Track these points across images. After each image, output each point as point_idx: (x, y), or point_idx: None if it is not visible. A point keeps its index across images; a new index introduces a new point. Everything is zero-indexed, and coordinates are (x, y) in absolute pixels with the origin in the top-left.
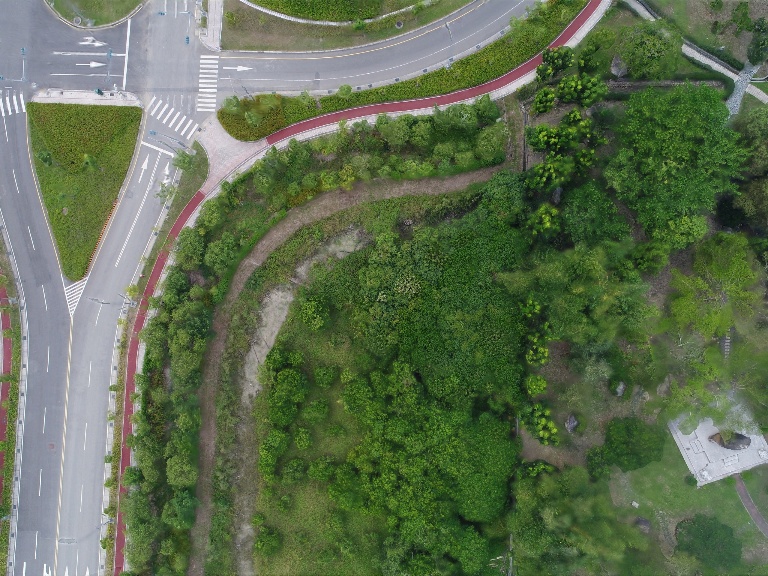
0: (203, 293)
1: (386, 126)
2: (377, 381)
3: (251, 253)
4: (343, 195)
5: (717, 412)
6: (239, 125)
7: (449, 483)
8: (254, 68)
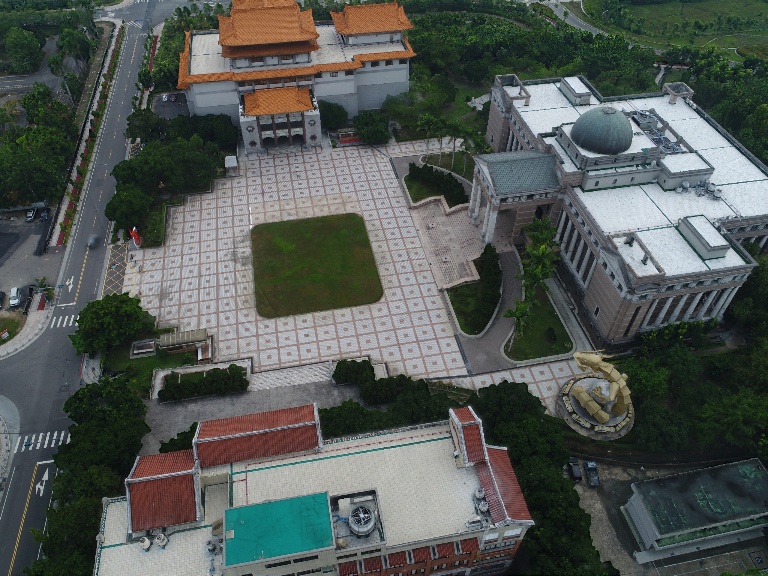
0: (470, 4)
1: (560, 20)
2: None
3: (490, 14)
4: (527, 27)
5: None
6: (536, 5)
7: None
8: (559, 8)
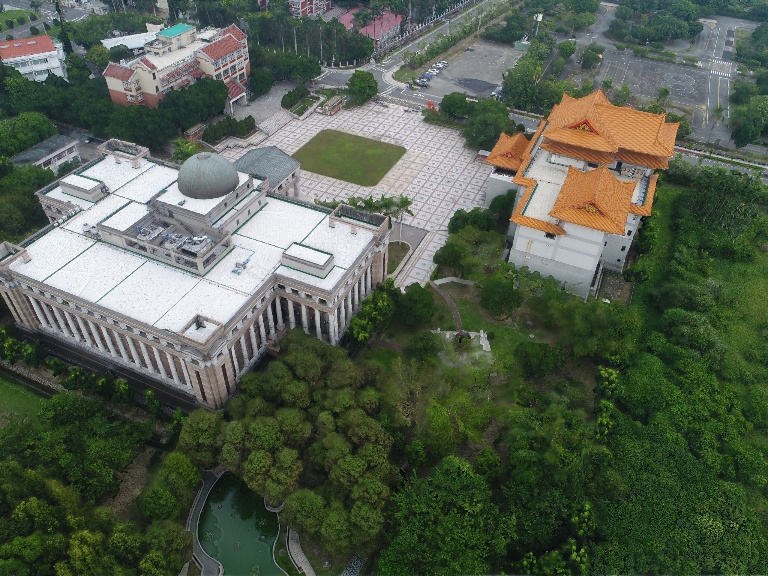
0: None
1: None
2: (731, 468)
3: None
4: None
5: (480, 350)
6: None
7: (674, 380)
8: None
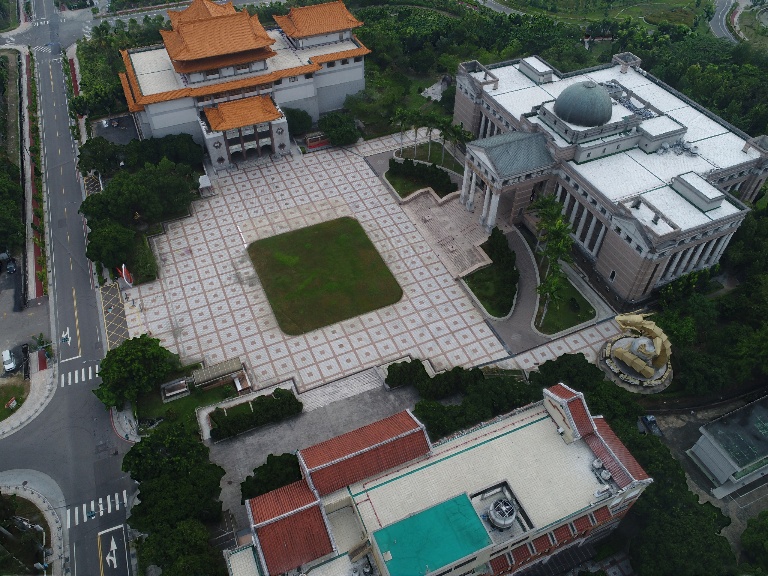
0: None
1: (482, 5)
2: None
3: None
4: None
5: None
6: None
7: None
8: None
